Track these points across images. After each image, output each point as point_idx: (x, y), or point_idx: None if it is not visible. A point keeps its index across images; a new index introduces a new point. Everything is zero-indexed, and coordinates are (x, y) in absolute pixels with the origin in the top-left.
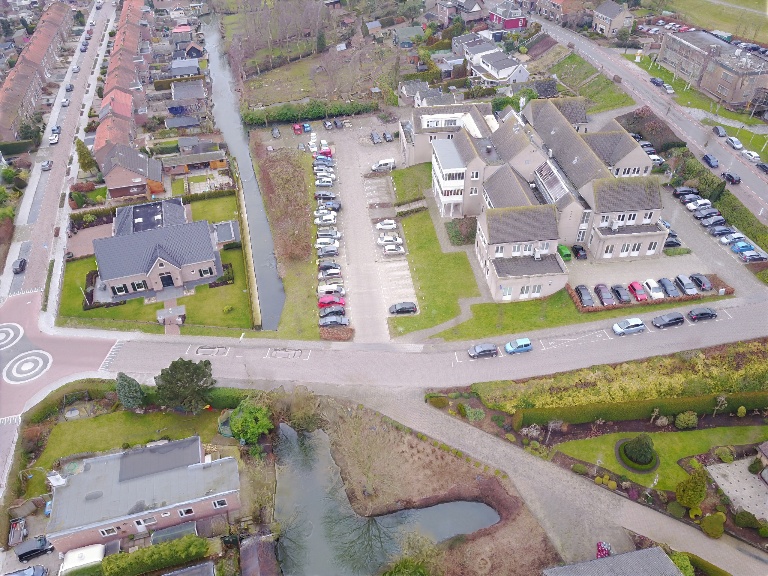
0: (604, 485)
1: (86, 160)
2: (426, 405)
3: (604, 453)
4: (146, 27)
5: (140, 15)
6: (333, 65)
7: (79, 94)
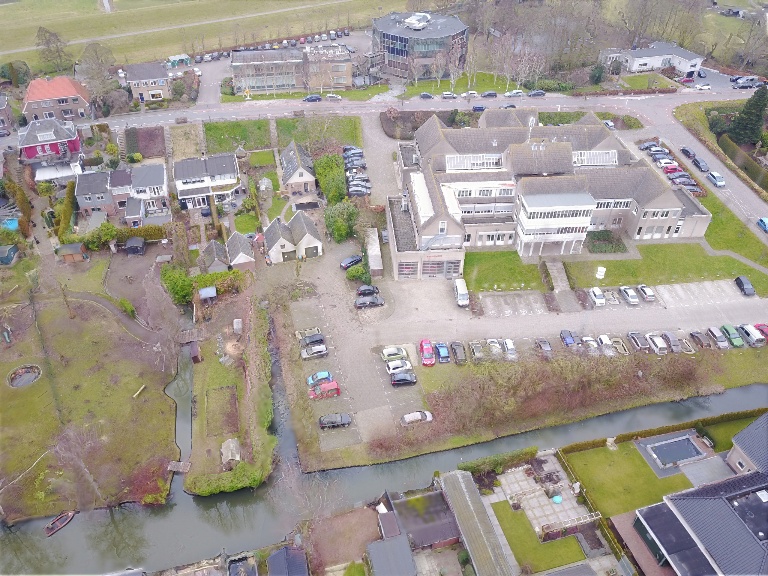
0: None
1: None
2: None
3: None
4: None
5: None
6: None
7: None
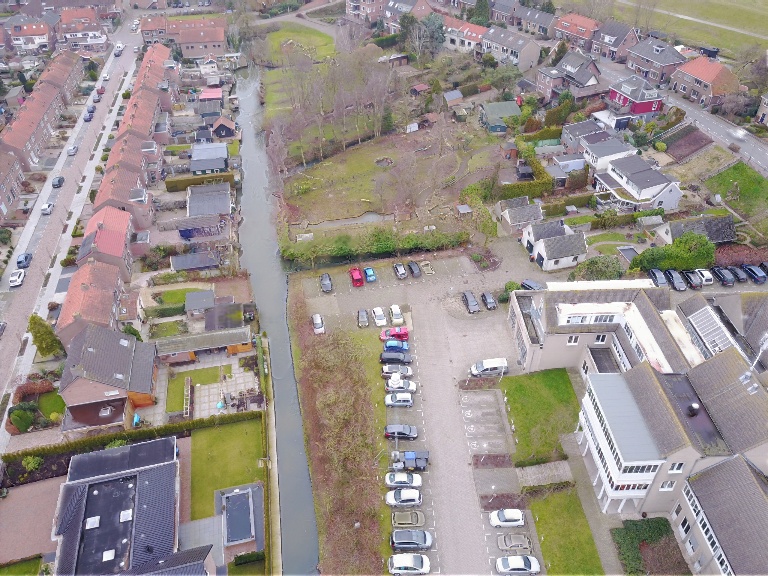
0: None
1: (44, 343)
2: None
3: None
4: (166, 91)
5: (161, 73)
6: (408, 175)
7: (68, 193)
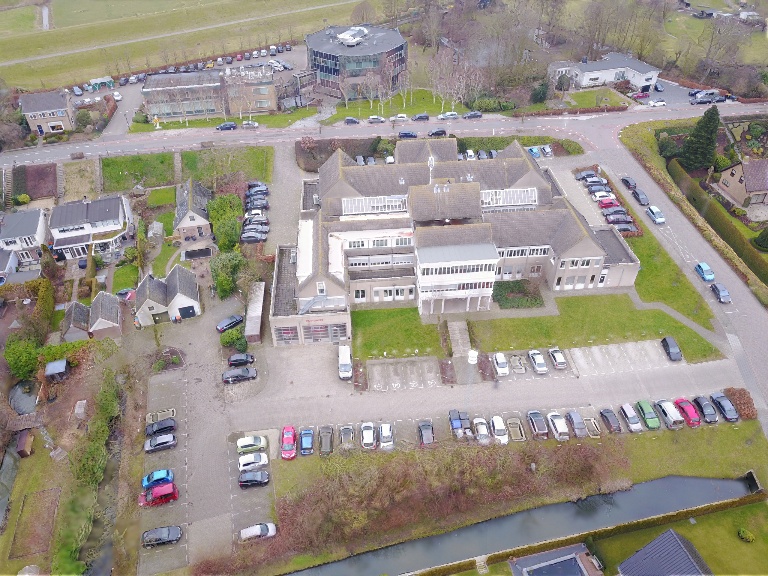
0: None
1: None
2: None
3: None
4: None
5: None
6: None
7: None
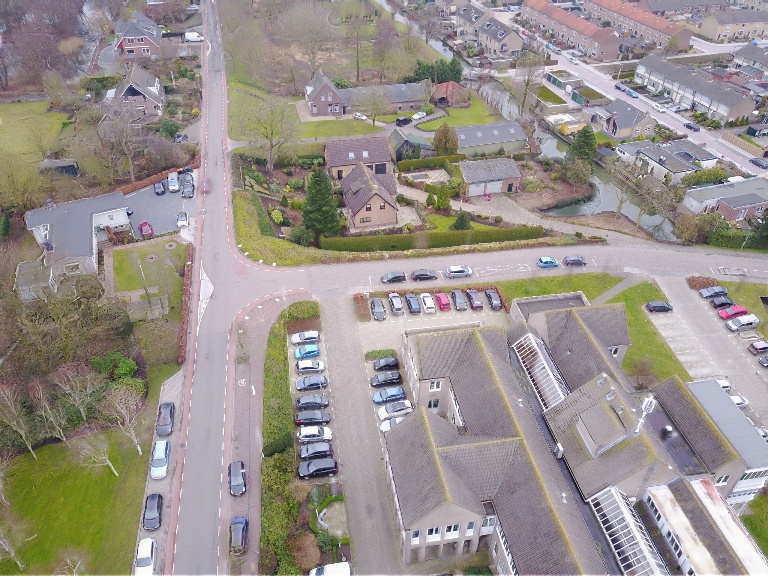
0: None
1: None
2: None
3: None
4: None
5: None
6: None
7: None
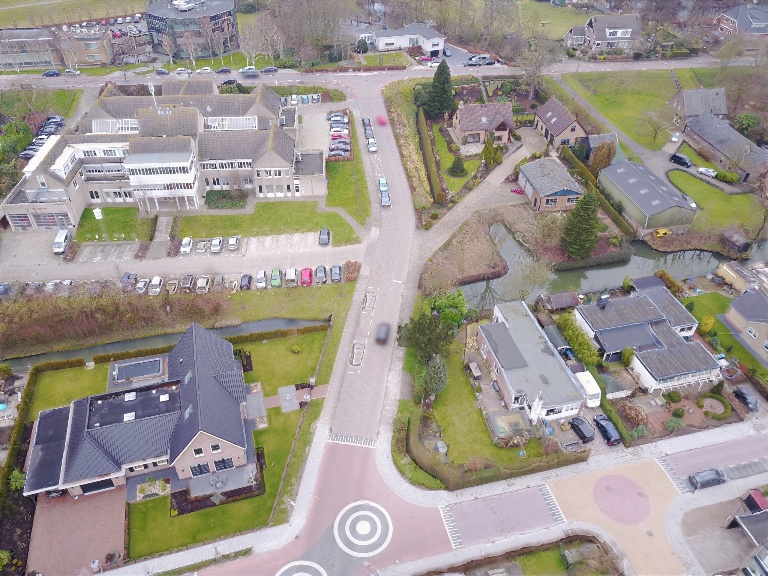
0: (478, 184)
1: None
2: (429, 230)
3: (456, 181)
4: None
5: None
6: None
7: None
